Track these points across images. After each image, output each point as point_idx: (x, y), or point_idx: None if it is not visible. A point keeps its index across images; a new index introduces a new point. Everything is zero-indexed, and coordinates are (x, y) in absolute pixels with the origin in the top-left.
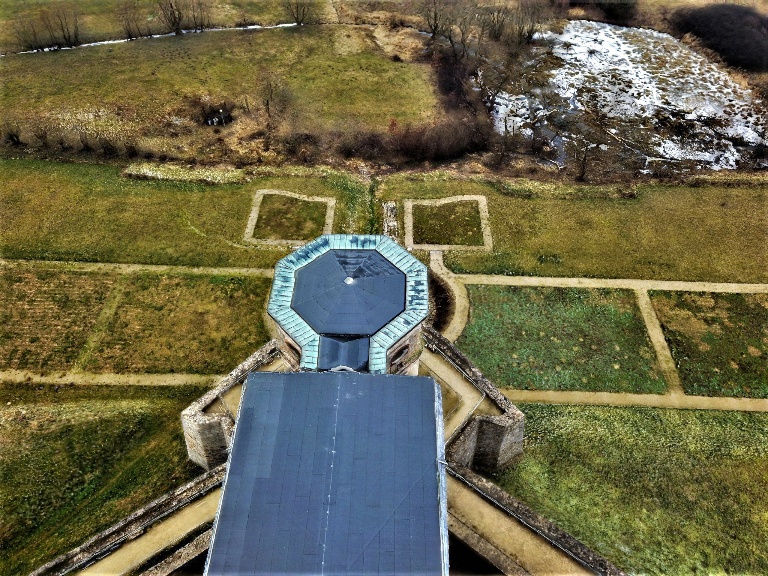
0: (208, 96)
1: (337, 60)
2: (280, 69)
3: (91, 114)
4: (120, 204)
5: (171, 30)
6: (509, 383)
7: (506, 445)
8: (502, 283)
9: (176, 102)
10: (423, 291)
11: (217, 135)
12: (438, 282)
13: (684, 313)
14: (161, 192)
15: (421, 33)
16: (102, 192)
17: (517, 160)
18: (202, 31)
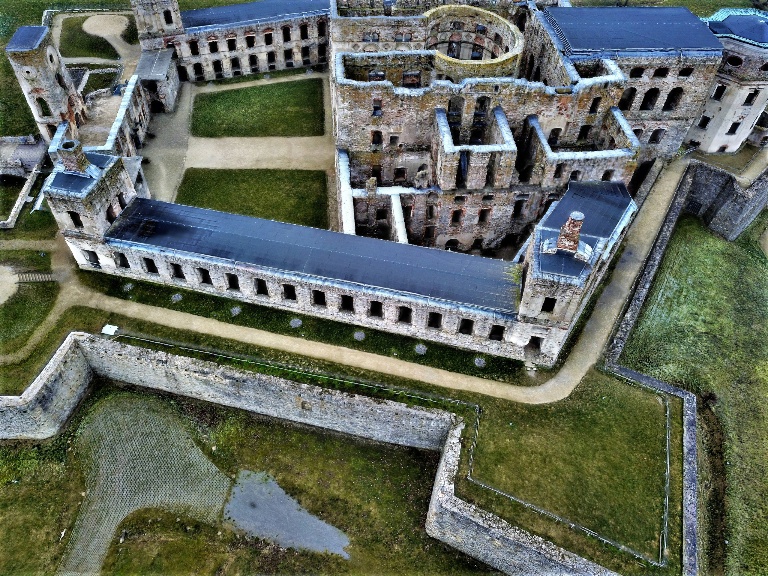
0: None
1: None
2: None
3: None
4: None
5: None
6: None
7: (725, 212)
8: None
9: None
10: None
11: None
12: None
13: None
14: None
15: None
16: None
17: None
18: None
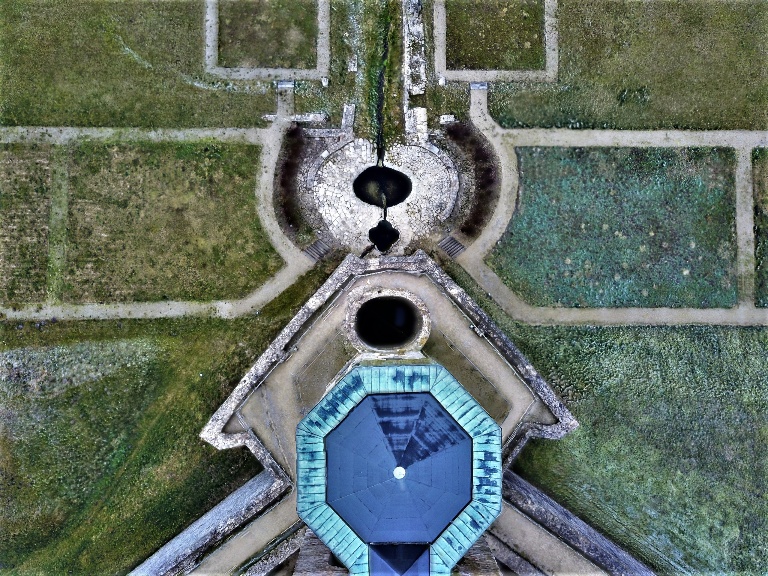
0: None
1: None
2: None
3: None
4: (7, 4)
5: None
6: (557, 299)
7: None
8: (564, 143)
9: None
10: (495, 472)
11: None
12: (480, 143)
13: None
14: None
15: None
16: None
17: None
18: None
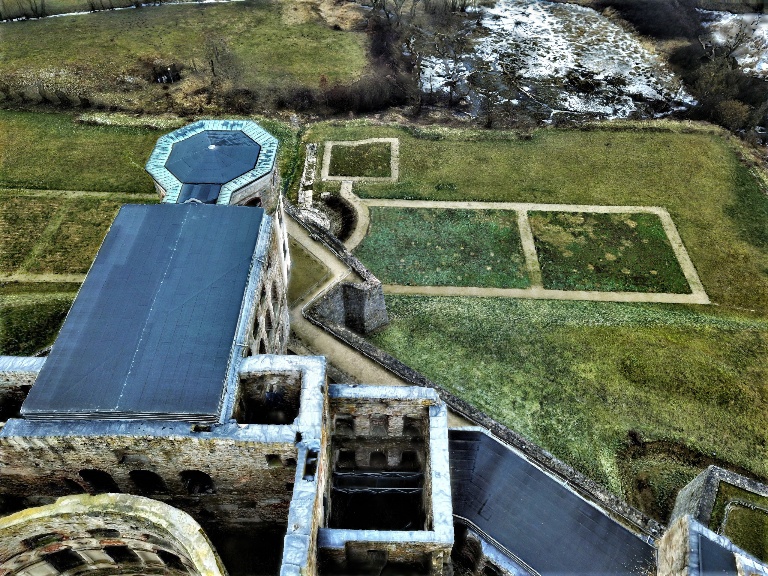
0: (160, 59)
1: (282, 29)
2: (229, 37)
3: (52, 73)
4: (71, 144)
5: (132, 4)
6: (394, 280)
7: (369, 311)
8: (401, 205)
9: (131, 64)
10: (271, 156)
11: (165, 91)
12: (345, 205)
13: (555, 228)
14: (108, 135)
15: (363, 7)
16: (55, 135)
17: (435, 112)
18: (160, 4)
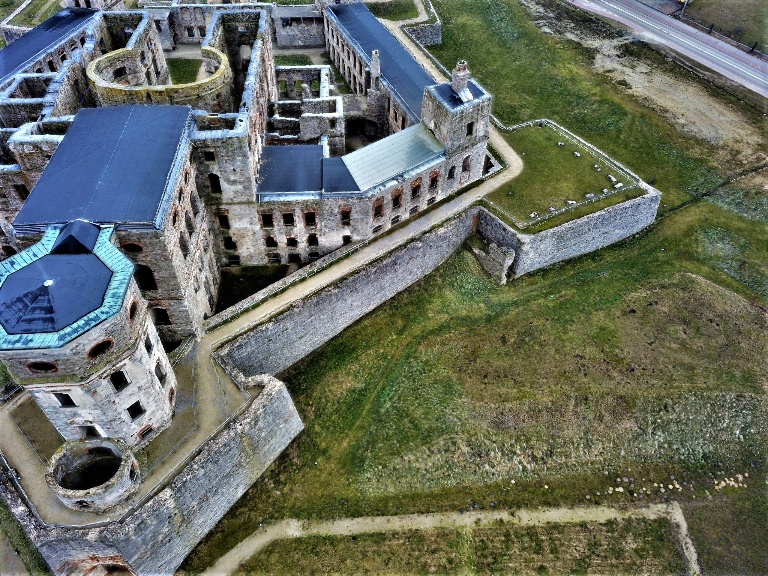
0: None
1: None
2: None
3: None
4: None
5: None
6: None
7: None
8: None
9: None
10: None
11: None
12: None
13: None
14: None
15: None
16: None
17: None
18: None
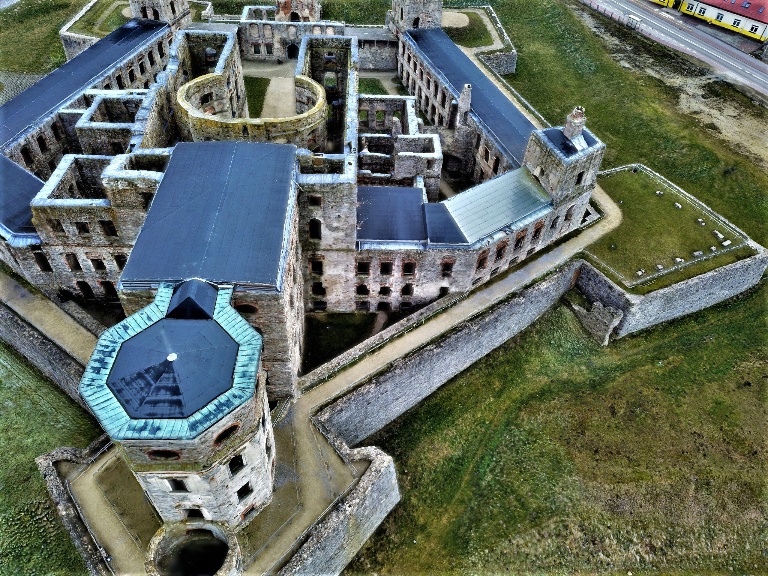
0: None
1: None
2: None
3: None
4: None
5: None
6: None
7: None
8: None
9: None
10: (95, 359)
11: None
12: None
13: None
14: None
15: None
16: None
17: None
18: None
